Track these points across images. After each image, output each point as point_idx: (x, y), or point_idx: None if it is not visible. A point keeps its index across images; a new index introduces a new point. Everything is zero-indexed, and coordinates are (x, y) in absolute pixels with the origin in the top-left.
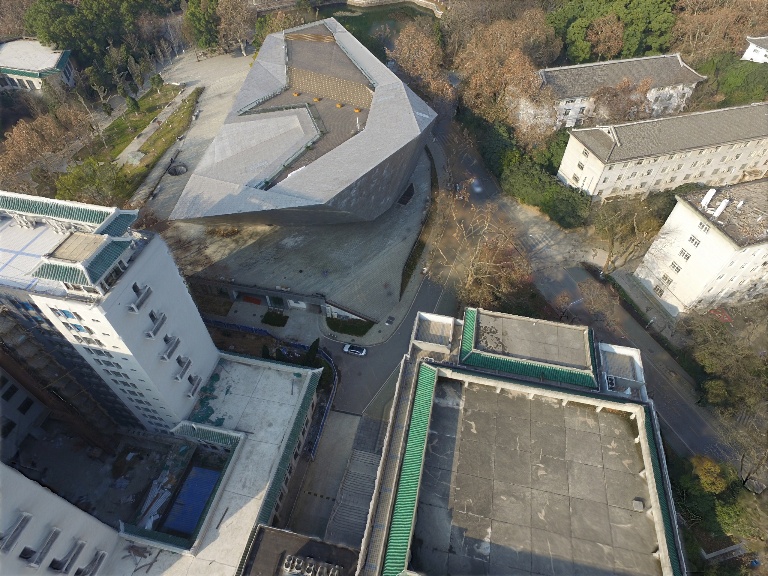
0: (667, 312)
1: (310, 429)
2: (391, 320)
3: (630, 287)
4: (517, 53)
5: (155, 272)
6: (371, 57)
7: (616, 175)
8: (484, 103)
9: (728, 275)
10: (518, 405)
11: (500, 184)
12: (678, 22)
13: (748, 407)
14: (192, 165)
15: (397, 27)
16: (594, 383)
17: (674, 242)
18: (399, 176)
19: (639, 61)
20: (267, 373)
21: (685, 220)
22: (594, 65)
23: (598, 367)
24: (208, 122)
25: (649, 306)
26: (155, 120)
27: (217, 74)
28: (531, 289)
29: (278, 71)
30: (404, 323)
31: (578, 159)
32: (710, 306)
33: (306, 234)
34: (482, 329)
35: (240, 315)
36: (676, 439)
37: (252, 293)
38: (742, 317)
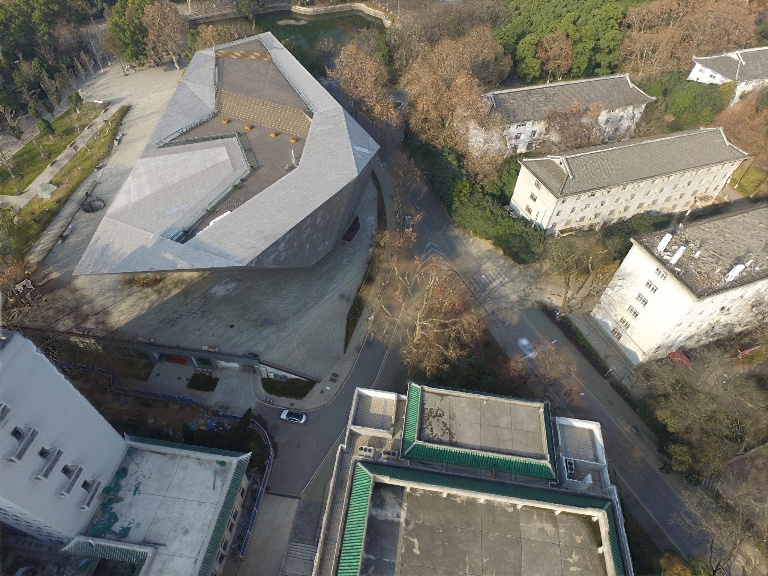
0: (626, 357)
1: (240, 520)
2: (335, 377)
3: (587, 328)
4: (464, 76)
5: (17, 380)
6: (310, 78)
7: (569, 208)
8: (432, 128)
9: (686, 322)
10: (467, 512)
11: (451, 216)
12: (626, 40)
13: (712, 470)
14: (111, 199)
15: (344, 37)
16: (552, 474)
17: (631, 286)
18: (337, 220)
19: (589, 82)
20: (185, 463)
21: (641, 264)
22: (544, 87)
23: (556, 447)
24: (132, 147)
25: (607, 350)
26: (72, 144)
27: (146, 90)
28: (485, 336)
29: (206, 94)
30: (349, 380)
31: (530, 190)
32: (669, 350)
33: (239, 280)
34: (427, 412)
35: (163, 379)
36: (640, 509)
37: (175, 354)
38: (700, 359)
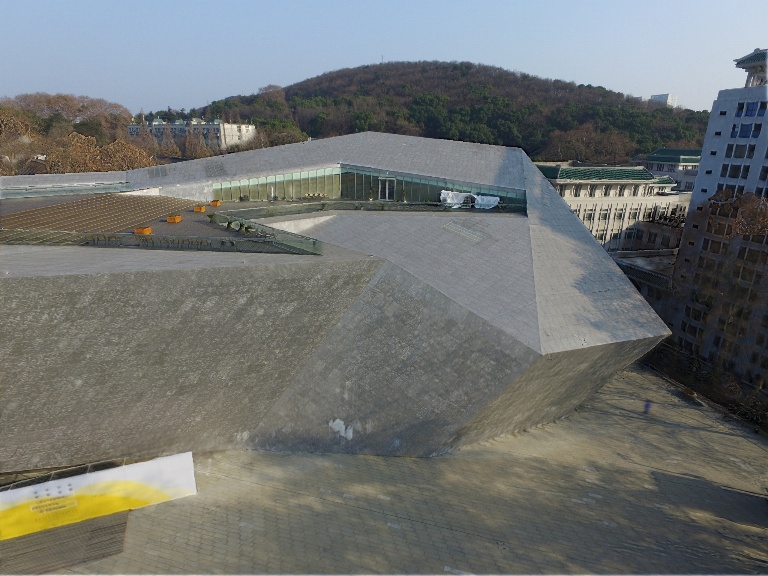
0: None
1: None
2: None
3: None
4: None
5: None
6: None
7: None
8: None
9: None
10: None
11: None
12: None
13: None
14: None
15: None
16: None
17: None
18: None
19: None
20: None
21: None
22: None
23: None
24: None
25: None
26: None
27: None
28: None
29: None
30: None
31: None
32: None
33: None
34: None
35: None
36: None
37: None
38: None
